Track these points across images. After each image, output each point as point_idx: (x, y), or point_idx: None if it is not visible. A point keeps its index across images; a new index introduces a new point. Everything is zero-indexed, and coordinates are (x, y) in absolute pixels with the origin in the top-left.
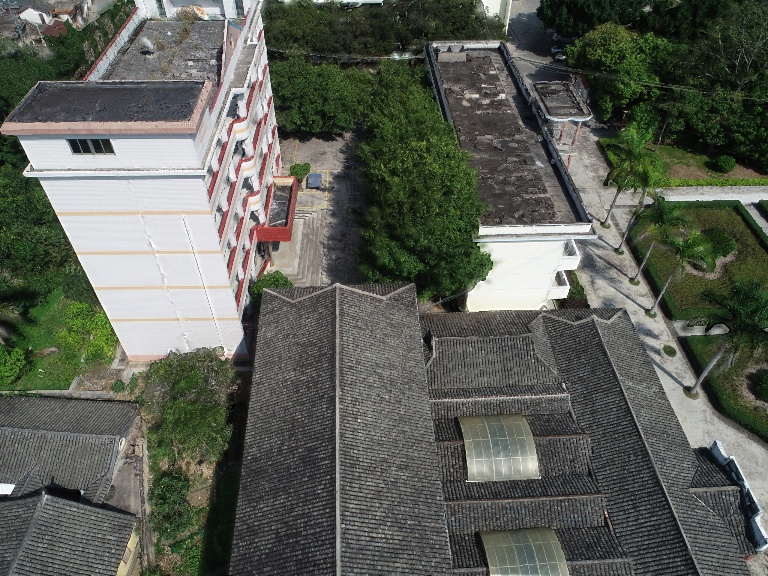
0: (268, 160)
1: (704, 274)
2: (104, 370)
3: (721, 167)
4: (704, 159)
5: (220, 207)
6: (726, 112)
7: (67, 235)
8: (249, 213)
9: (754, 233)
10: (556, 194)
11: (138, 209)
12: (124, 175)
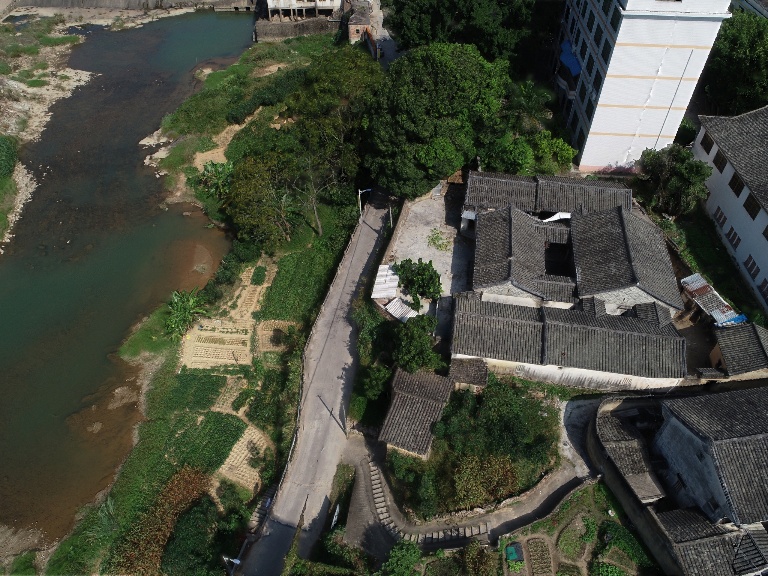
0: None
1: None
2: (568, 172)
3: None
4: None
5: None
6: None
7: (611, 61)
8: None
9: None
10: None
11: (668, 43)
12: (680, 16)
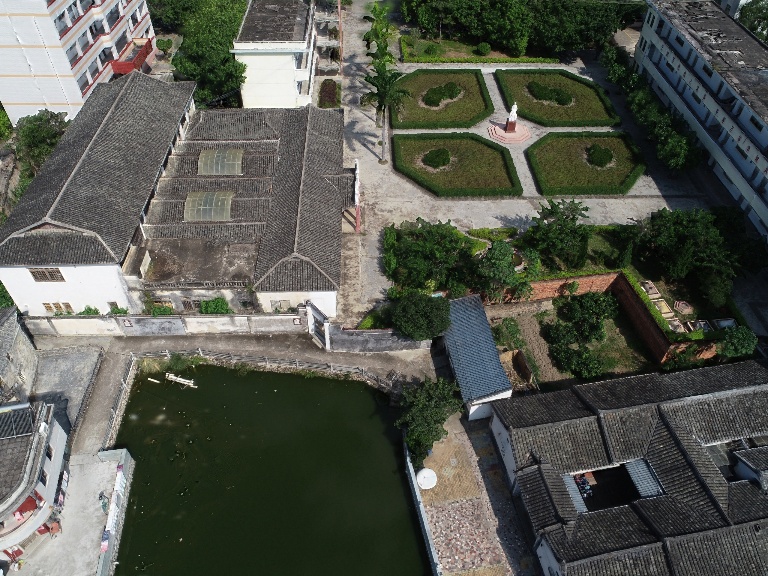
0: (125, 21)
1: (430, 107)
2: (2, 143)
3: (479, 51)
4: (474, 48)
5: (66, 24)
6: (480, 9)
7: None
8: (102, 47)
9: (480, 87)
10: (298, 32)
11: (6, 12)
12: None
